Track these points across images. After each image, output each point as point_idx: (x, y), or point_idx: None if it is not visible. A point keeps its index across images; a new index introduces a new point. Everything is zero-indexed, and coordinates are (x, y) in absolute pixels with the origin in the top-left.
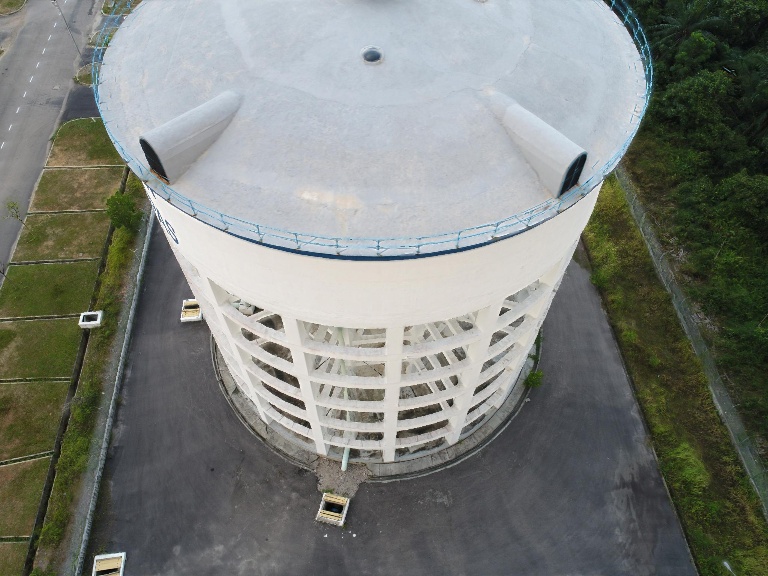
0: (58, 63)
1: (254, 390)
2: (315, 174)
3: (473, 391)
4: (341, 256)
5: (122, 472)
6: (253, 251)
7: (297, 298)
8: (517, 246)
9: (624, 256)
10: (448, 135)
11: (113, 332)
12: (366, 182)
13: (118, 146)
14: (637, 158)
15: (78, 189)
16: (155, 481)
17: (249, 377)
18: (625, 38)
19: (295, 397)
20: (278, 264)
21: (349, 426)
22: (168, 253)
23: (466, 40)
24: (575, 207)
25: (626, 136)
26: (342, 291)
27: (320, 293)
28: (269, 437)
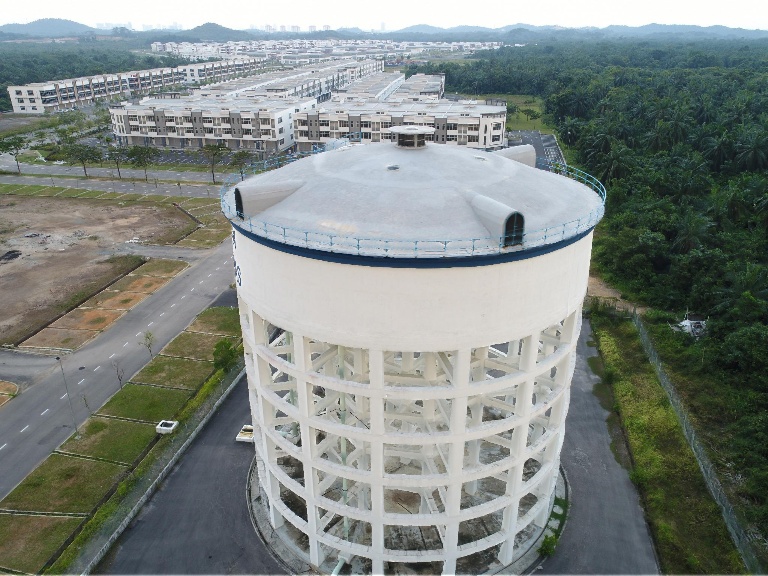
0: (224, 276)
1: (269, 467)
2: (334, 214)
3: (460, 488)
4: (334, 255)
5: (134, 541)
6: (282, 263)
7: (305, 310)
8: (473, 285)
9: (671, 467)
10: (429, 204)
11: (179, 439)
12: (365, 220)
13: (223, 204)
14: (696, 395)
15: (200, 346)
16: (157, 555)
17: (267, 446)
18: (597, 201)
19: (297, 457)
20: (296, 273)
21: (339, 507)
22: (247, 394)
23: (461, 169)
24: (527, 273)
25: (573, 232)
26: (336, 300)
27: (321, 303)
28: (272, 541)
